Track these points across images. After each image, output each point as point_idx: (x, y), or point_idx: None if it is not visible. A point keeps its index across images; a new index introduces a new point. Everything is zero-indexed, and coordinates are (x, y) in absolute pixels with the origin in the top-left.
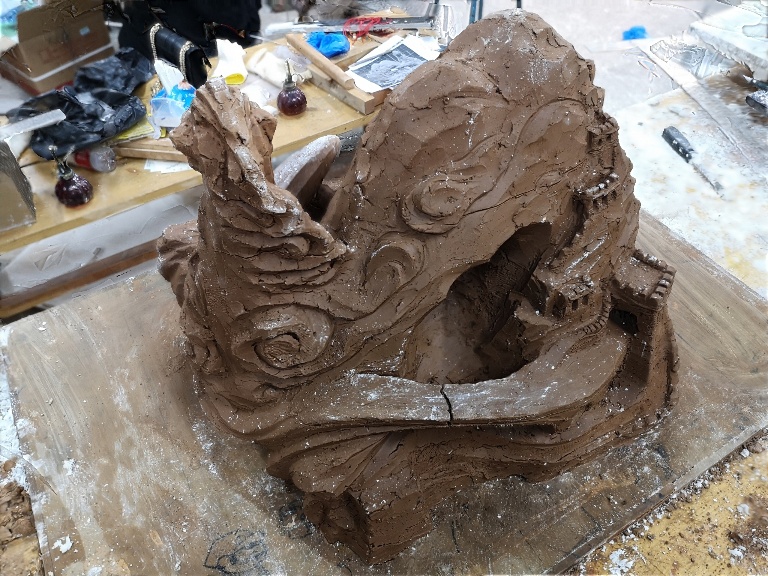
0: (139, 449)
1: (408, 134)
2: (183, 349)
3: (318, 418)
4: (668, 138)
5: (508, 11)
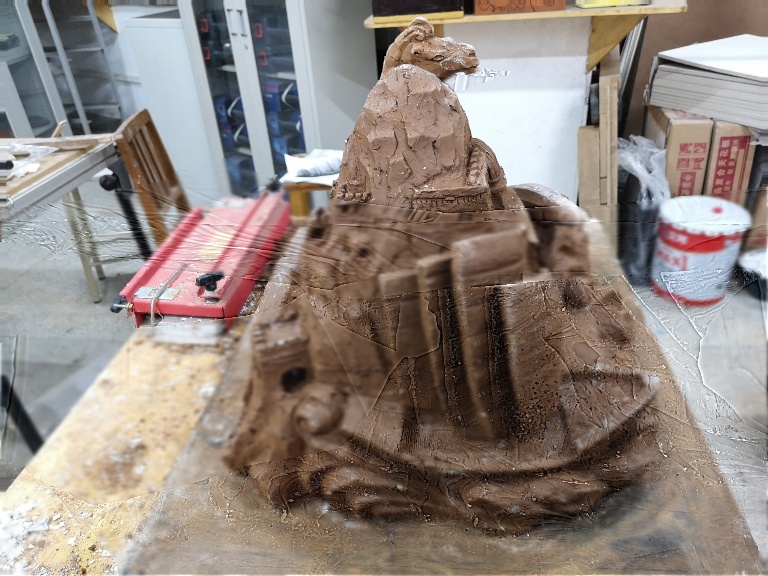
0: None
1: None
2: None
3: None
4: None
5: None
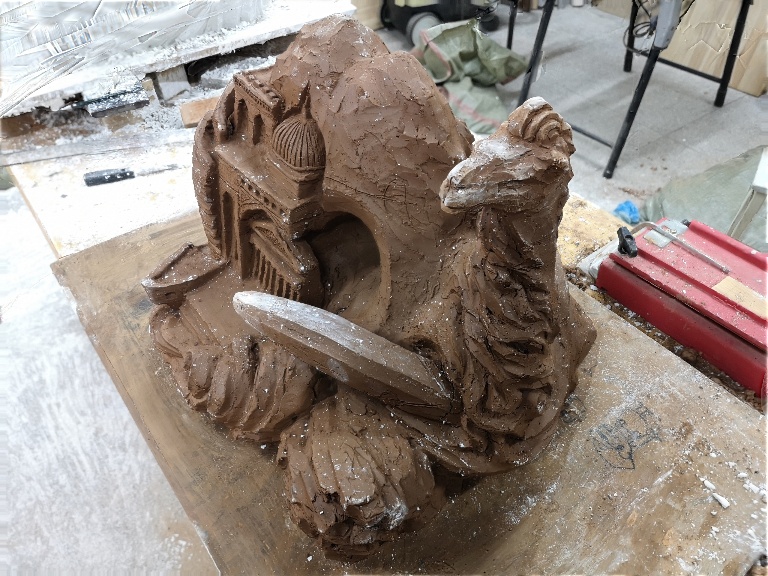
0: (558, 573)
1: (445, 105)
2: (419, 572)
3: (567, 299)
4: (98, 181)
5: (340, 17)
